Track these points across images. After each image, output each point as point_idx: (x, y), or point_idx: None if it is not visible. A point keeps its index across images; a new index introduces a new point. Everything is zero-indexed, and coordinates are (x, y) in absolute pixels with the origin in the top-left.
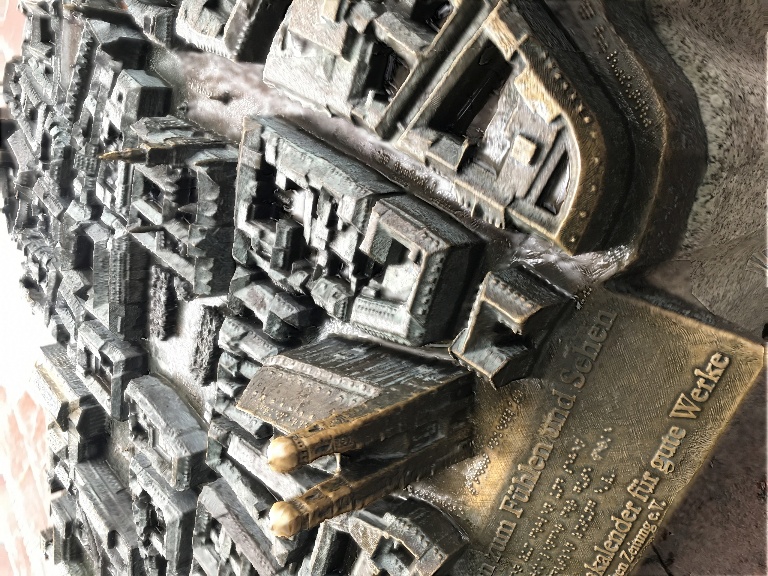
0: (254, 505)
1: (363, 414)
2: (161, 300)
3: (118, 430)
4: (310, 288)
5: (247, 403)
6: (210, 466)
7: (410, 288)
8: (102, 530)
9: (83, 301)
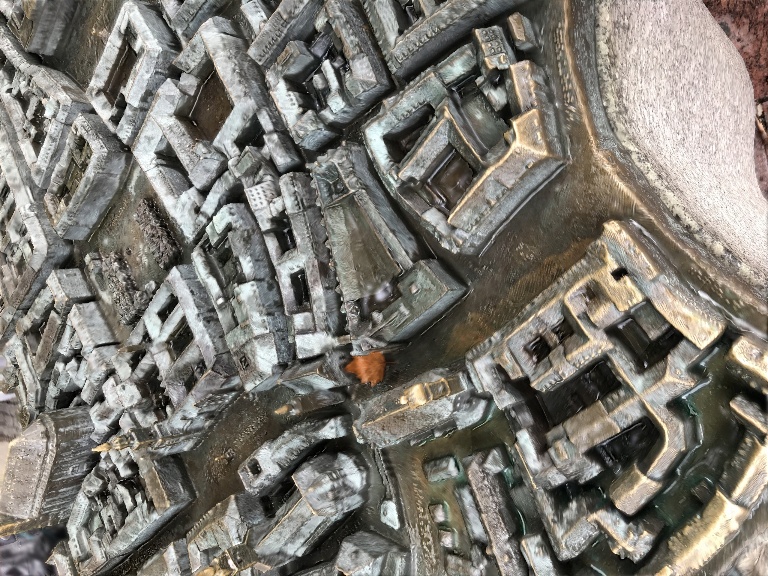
0: (34, 319)
1: (7, 532)
2: (151, 245)
3: (119, 4)
4: (101, 468)
5: (15, 449)
6: (46, 283)
7: (93, 530)
8: (26, 5)
9: (197, 21)
